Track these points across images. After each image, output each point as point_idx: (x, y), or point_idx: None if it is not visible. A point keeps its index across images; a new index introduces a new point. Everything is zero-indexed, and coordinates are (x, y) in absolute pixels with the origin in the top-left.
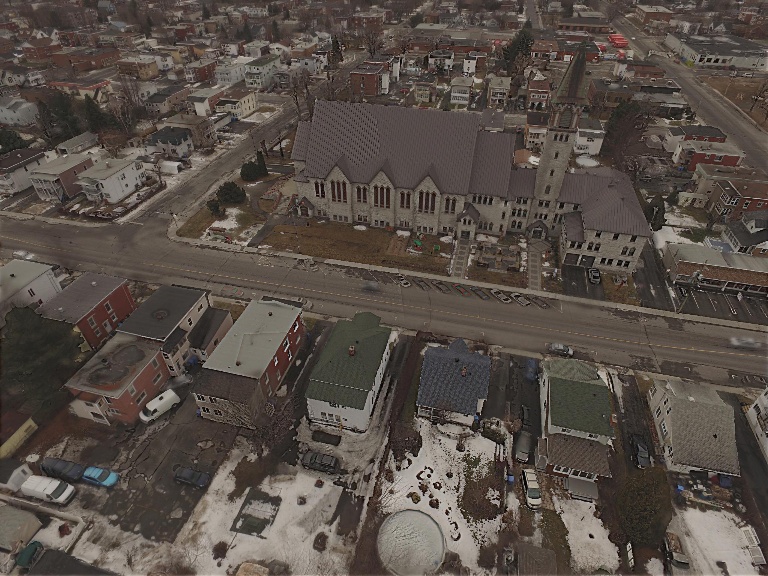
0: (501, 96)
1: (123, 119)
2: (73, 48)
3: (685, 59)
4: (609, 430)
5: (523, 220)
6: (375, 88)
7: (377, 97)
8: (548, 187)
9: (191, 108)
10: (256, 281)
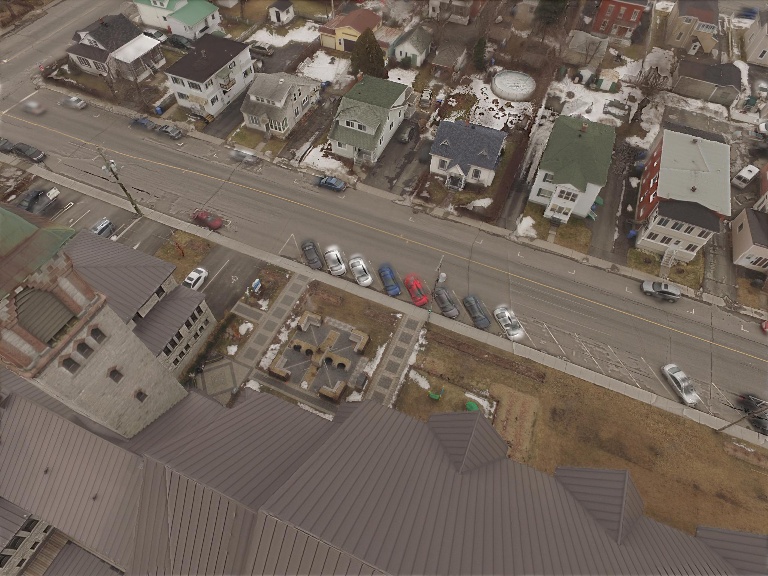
0: None
1: None
2: None
3: None
4: (366, 77)
5: None
6: None
7: None
8: None
9: None
10: (759, 358)
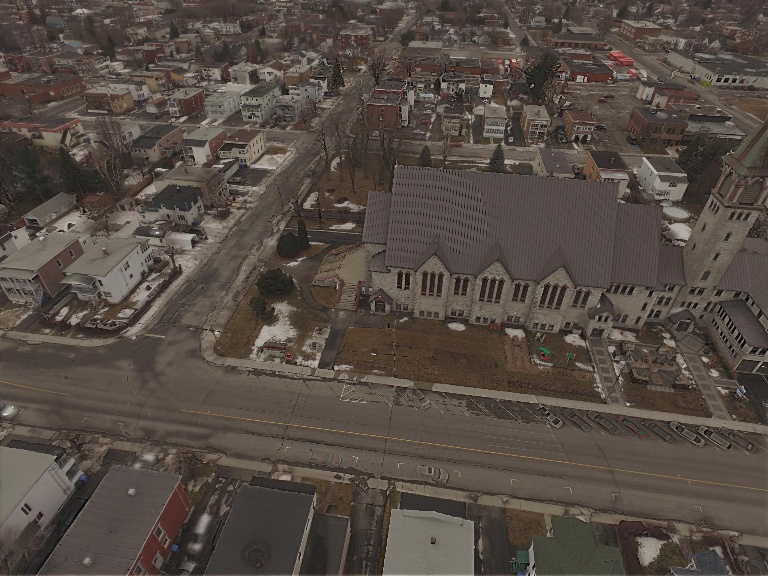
0: (541, 128)
1: (110, 176)
2: (25, 75)
3: (699, 79)
4: None
5: (663, 309)
6: (395, 120)
7: (398, 131)
8: (707, 272)
9: (188, 153)
10: (351, 433)
